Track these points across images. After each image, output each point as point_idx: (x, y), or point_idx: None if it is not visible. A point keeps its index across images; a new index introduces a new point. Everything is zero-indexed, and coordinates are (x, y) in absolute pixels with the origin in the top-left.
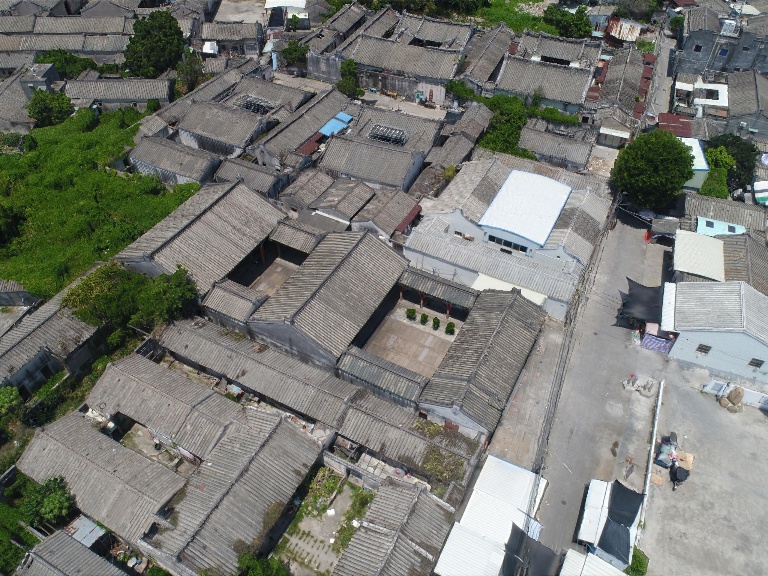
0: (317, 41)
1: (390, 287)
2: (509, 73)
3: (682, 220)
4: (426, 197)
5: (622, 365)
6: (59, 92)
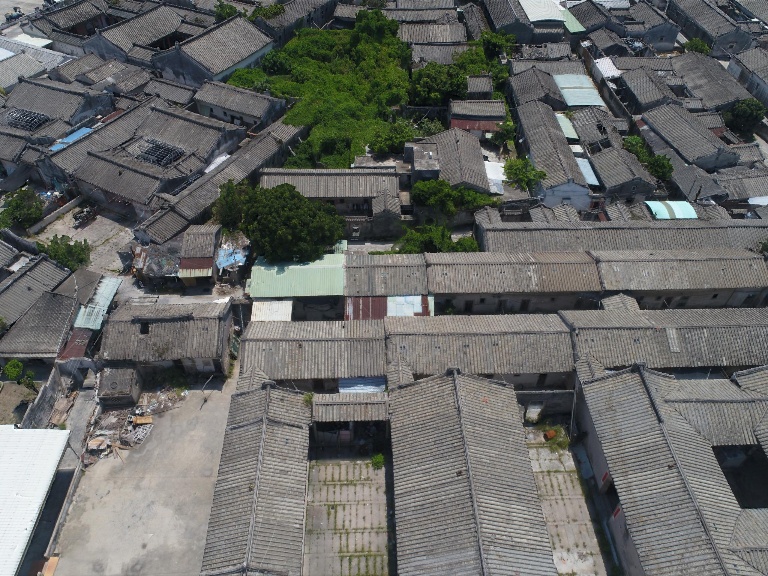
0: None
1: None
2: None
3: None
4: None
5: None
6: None
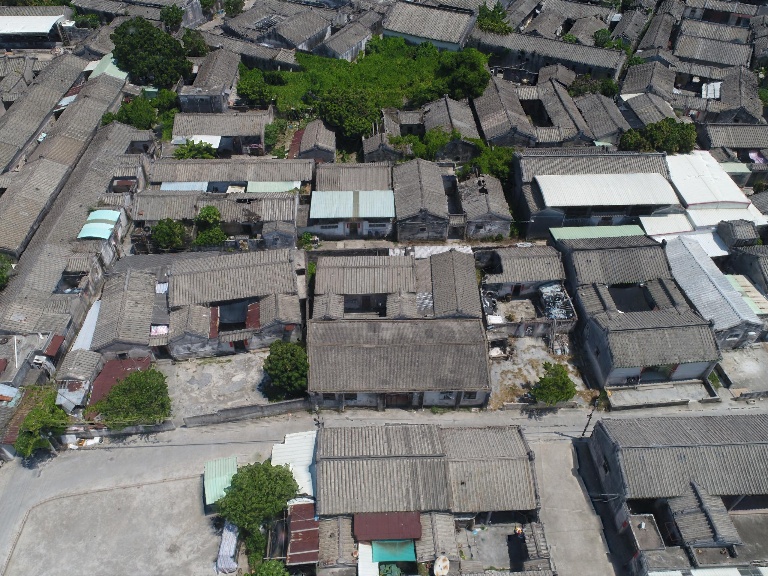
0: None
1: None
2: None
3: None
4: None
5: None
6: None
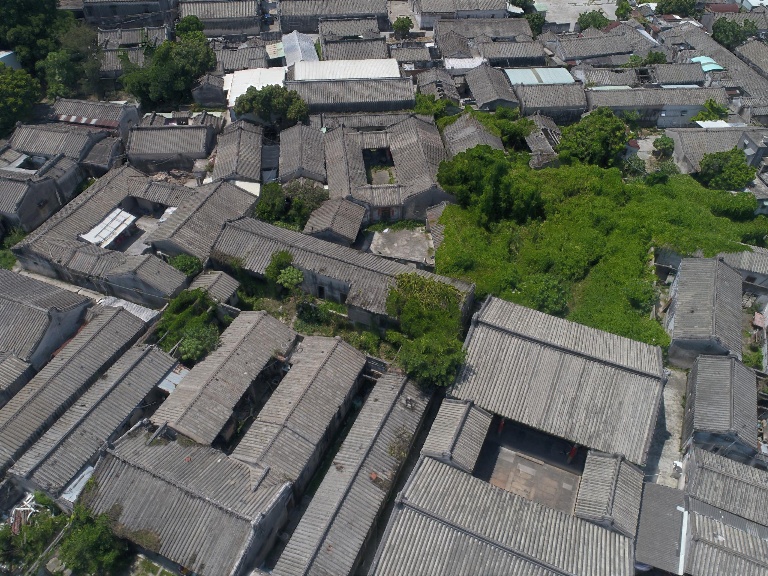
0: None
1: None
2: None
3: None
4: None
5: None
6: (762, 167)
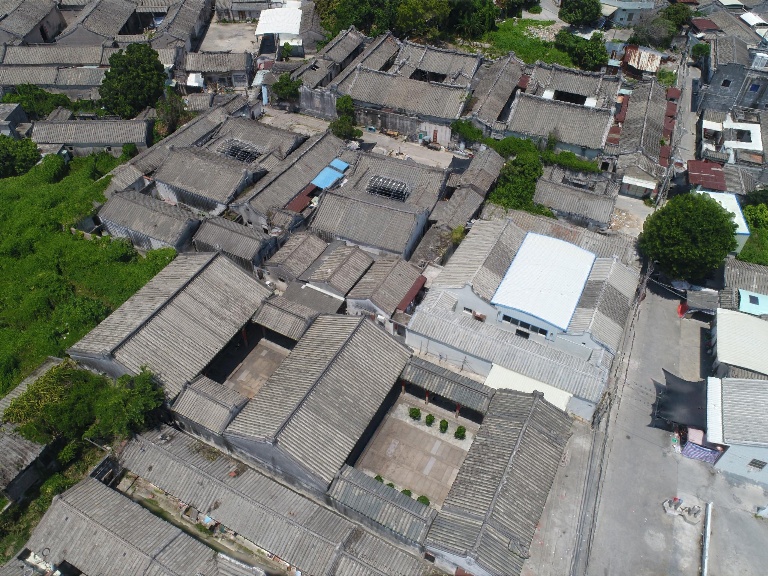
0: (311, 73)
1: (390, 386)
2: (521, 113)
3: (721, 293)
4: (431, 265)
5: (661, 480)
6: (25, 136)
